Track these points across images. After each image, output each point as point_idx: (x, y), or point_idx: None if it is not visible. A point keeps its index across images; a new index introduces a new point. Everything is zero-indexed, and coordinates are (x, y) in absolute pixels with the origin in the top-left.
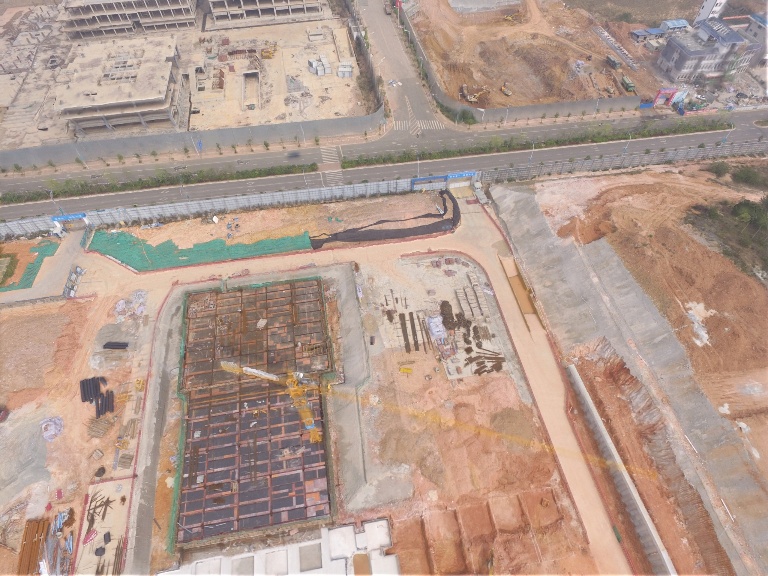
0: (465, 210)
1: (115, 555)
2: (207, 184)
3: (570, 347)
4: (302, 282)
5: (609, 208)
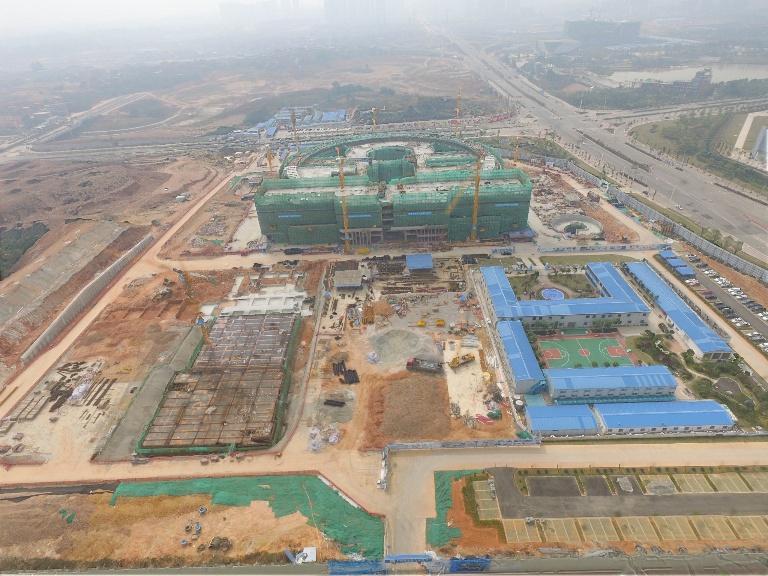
0: None
1: None
2: None
3: (7, 371)
4: (156, 445)
5: None
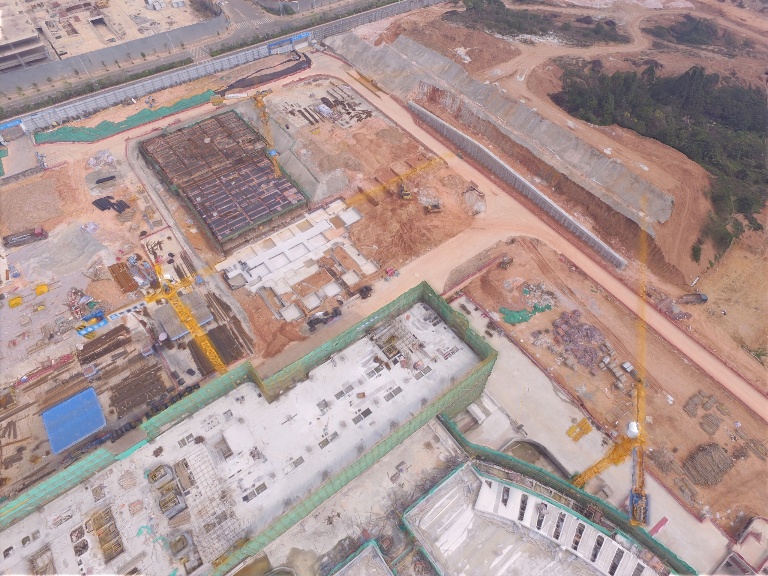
0: (312, 57)
1: (182, 260)
2: (109, 89)
3: (405, 96)
4: (222, 115)
5: (398, 24)
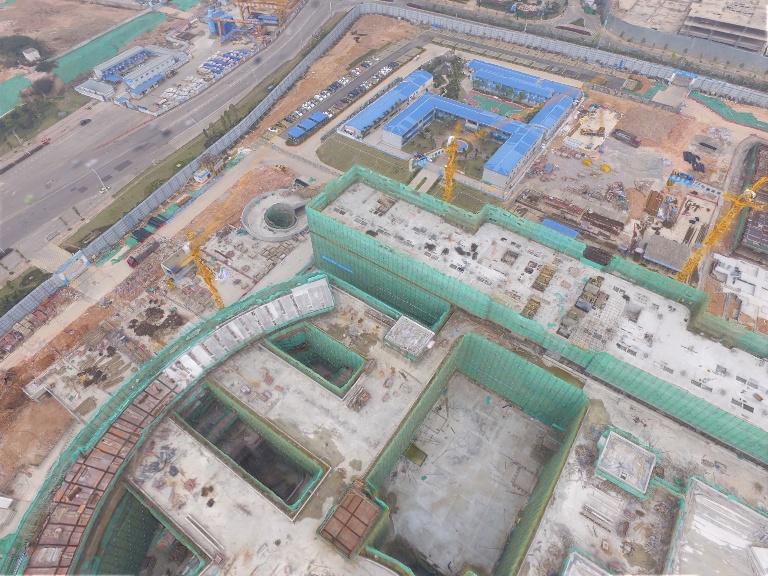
0: None
1: (701, 228)
2: None
3: None
4: None
5: None
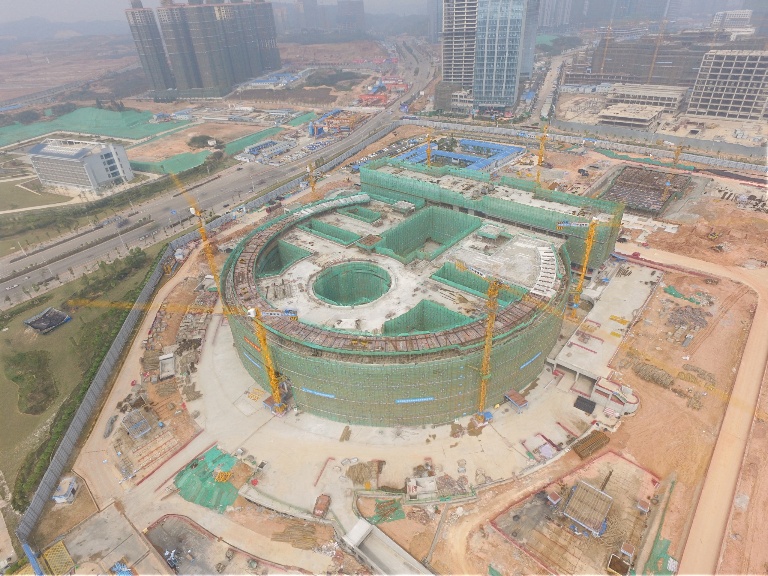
0: None
1: None
2: None
3: None
4: (681, 176)
5: None
